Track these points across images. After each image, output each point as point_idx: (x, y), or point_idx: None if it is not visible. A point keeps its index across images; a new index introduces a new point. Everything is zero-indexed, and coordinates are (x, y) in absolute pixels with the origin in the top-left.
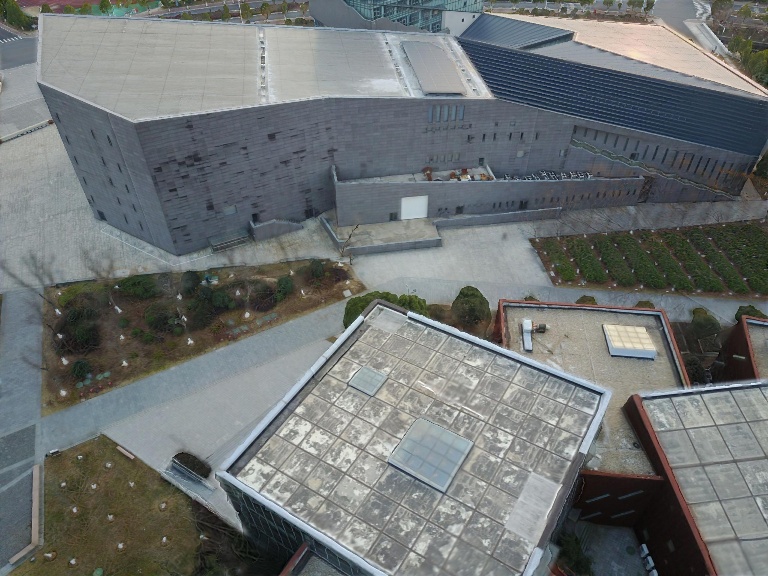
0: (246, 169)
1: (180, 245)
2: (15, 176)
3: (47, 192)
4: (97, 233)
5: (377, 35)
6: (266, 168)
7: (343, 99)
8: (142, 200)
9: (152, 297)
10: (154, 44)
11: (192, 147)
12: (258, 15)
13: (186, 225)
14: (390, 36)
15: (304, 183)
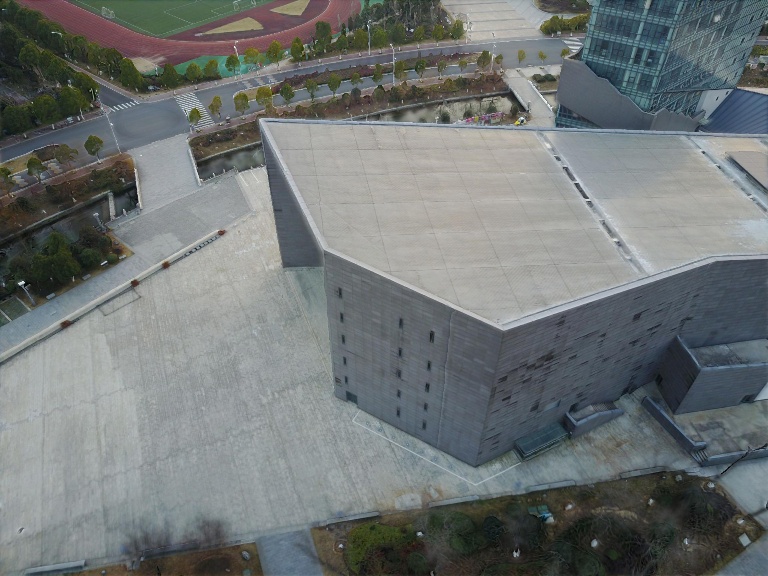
0: (591, 358)
1: (483, 455)
2: (204, 322)
3: (256, 350)
4: (349, 425)
5: (683, 140)
6: (612, 352)
7: (733, 261)
8: (449, 404)
9: (475, 552)
10: (431, 168)
11: (550, 345)
12: (405, 71)
13: (500, 432)
14: (699, 141)
15: (639, 360)
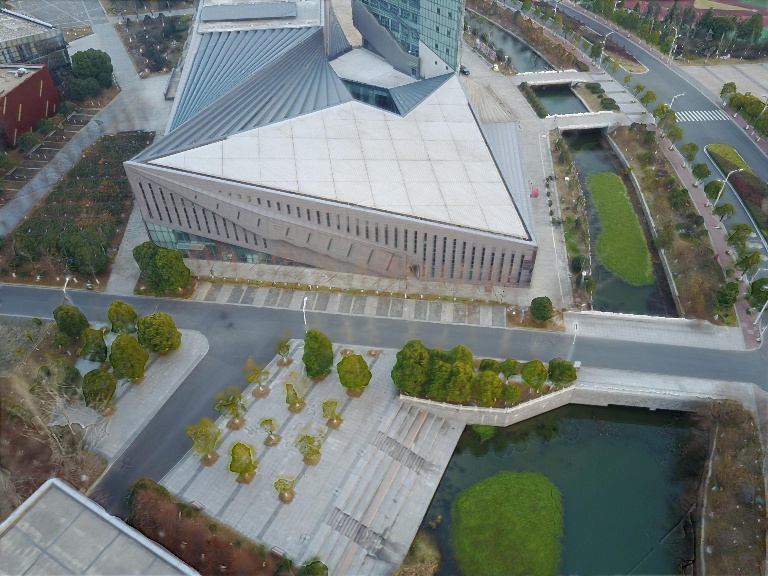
0: None
1: None
2: None
3: None
4: None
5: None
6: None
7: None
8: None
9: None
10: None
11: None
12: (582, 38)
13: None
14: (313, 2)
15: None
